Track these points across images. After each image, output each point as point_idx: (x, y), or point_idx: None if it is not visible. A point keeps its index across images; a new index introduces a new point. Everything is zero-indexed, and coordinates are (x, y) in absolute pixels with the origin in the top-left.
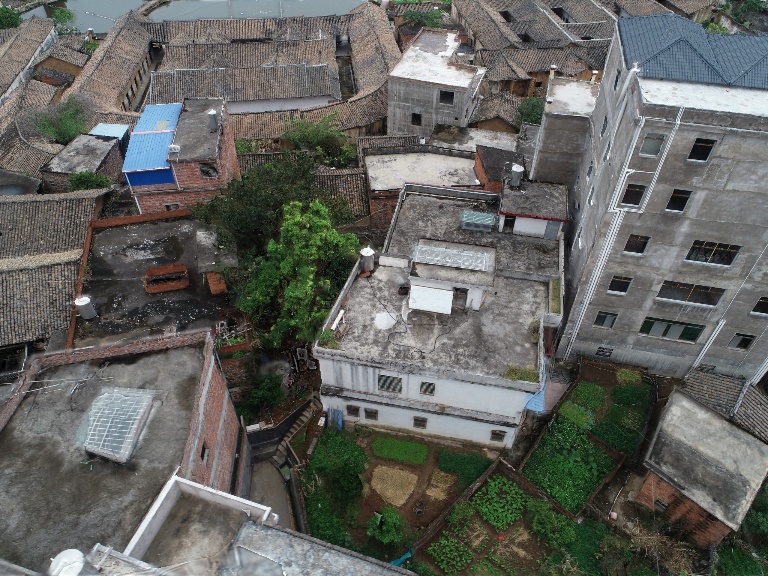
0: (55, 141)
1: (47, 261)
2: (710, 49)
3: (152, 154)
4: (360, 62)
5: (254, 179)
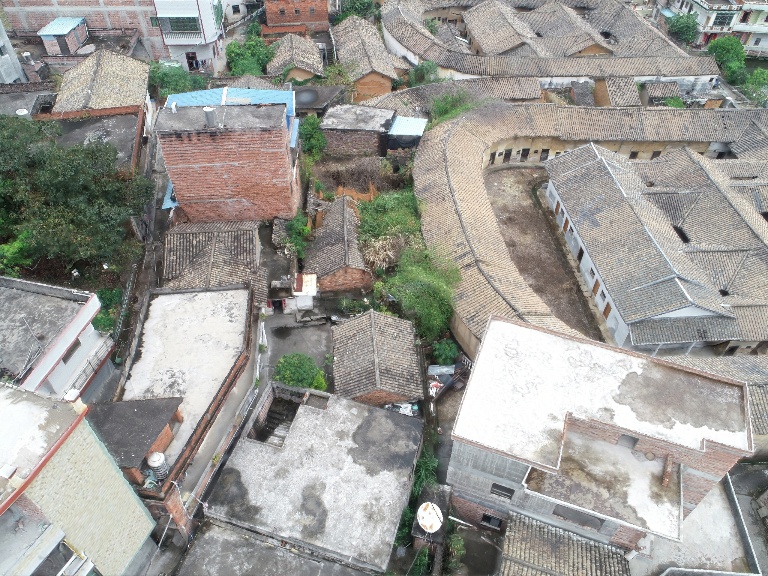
0: (427, 113)
1: (114, 102)
2: None
3: (188, 103)
4: (762, 359)
5: (4, 122)
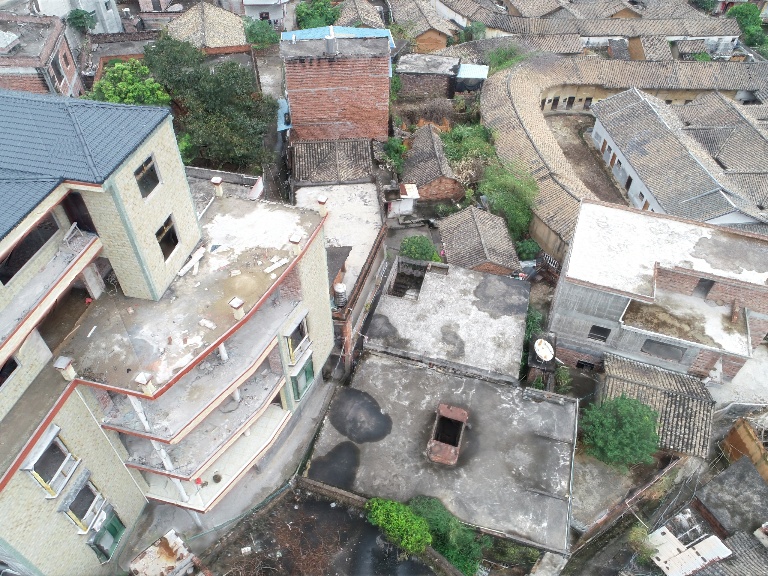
0: (483, 64)
1: (224, 44)
2: (7, 164)
3: (302, 38)
4: None
5: None
